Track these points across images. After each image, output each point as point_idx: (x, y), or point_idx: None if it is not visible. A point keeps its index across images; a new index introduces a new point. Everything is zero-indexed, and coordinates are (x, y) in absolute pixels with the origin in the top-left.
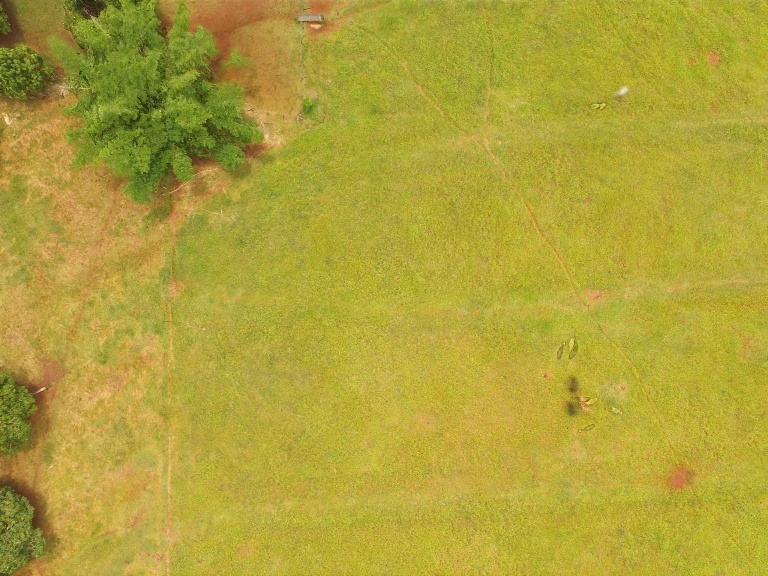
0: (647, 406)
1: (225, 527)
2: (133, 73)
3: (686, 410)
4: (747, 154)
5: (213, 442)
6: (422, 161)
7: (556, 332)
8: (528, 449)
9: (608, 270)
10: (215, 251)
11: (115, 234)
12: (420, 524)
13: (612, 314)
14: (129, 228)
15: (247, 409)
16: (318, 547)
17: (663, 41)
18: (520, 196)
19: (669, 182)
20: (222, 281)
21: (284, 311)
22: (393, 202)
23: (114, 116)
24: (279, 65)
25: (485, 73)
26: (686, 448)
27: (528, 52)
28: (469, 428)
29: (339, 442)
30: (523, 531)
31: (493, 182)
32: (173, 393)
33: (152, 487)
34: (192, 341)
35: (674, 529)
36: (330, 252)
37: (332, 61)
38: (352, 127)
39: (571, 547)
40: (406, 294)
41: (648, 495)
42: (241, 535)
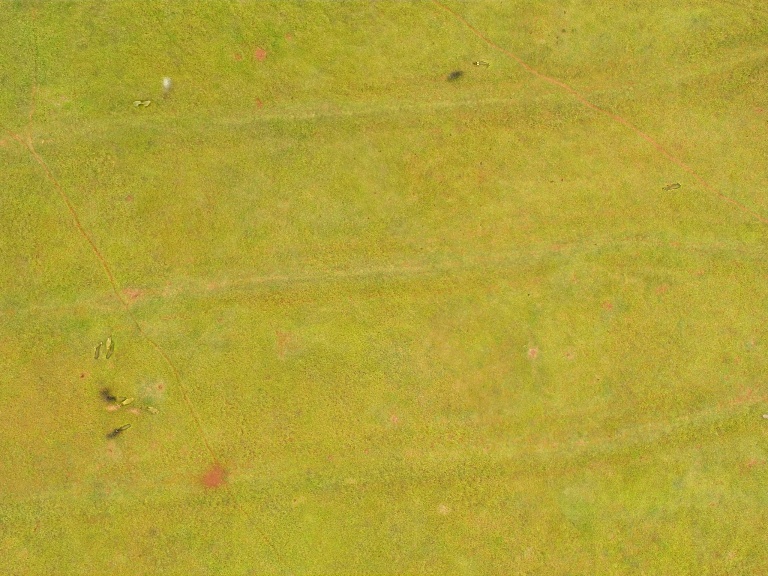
0: (183, 405)
1: None
2: None
3: (223, 408)
4: (291, 150)
5: None
6: None
7: (93, 332)
8: (63, 450)
9: (149, 268)
10: None
11: None
12: None
13: (151, 313)
14: None
15: None
16: None
17: (209, 37)
18: (63, 195)
19: (212, 179)
20: None
21: None
22: None
23: None
24: None
25: (30, 71)
26: (223, 447)
27: (72, 50)
28: (4, 430)
29: None
30: (54, 533)
31: (36, 181)
32: None
33: None
34: None
35: (207, 528)
36: None
37: None
38: None
39: (102, 548)
40: None
41: (182, 495)
42: None
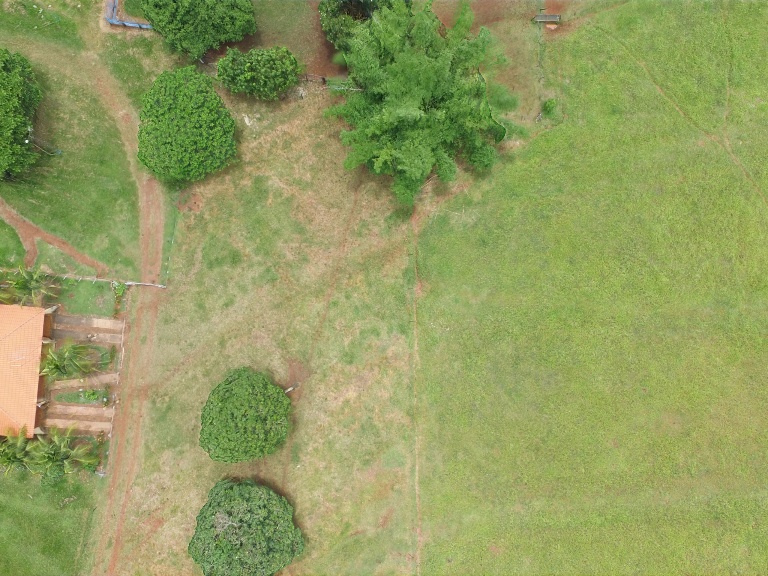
0: None
1: (475, 527)
2: (425, 74)
3: None
4: None
5: (460, 442)
6: (663, 161)
7: None
8: None
9: None
10: (458, 251)
11: (358, 234)
12: (669, 524)
13: None
14: (371, 228)
15: (493, 409)
16: (568, 547)
17: None
18: (761, 196)
19: None
20: (467, 281)
21: (530, 311)
22: (635, 202)
23: (398, 117)
24: (517, 65)
25: (724, 73)
26: None
27: (767, 52)
28: (715, 428)
29: (586, 442)
30: None
31: (734, 182)
32: (420, 393)
33: (400, 487)
34: (437, 341)
35: None
36: (573, 252)
37: (570, 61)
38: (592, 127)
39: None
40: (651, 294)
41: None
42: (491, 535)
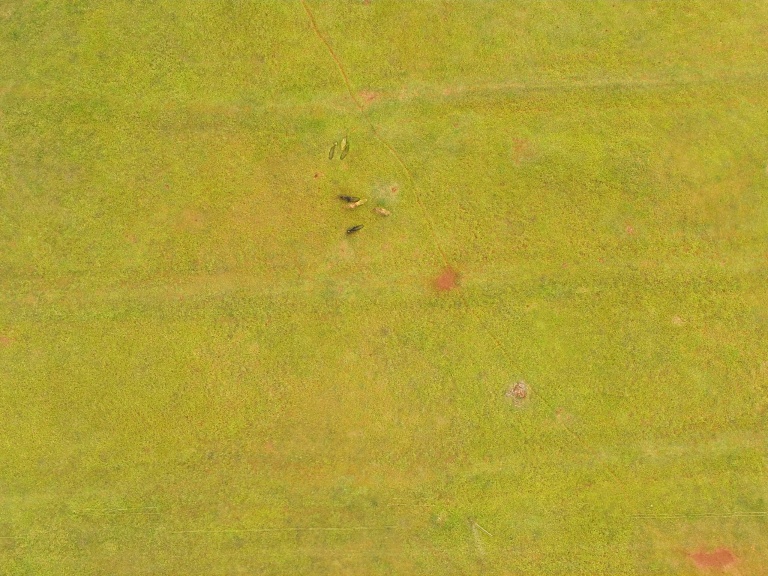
0: (417, 208)
1: None
2: None
3: (456, 213)
4: None
5: None
6: None
7: (328, 132)
8: (295, 248)
9: (384, 72)
10: None
11: None
12: (183, 320)
13: (386, 116)
14: None
15: (14, 201)
16: (78, 339)
17: None
18: None
19: None
20: None
21: (54, 104)
22: None
23: None
24: None
25: None
26: (455, 251)
27: None
28: (237, 226)
29: (105, 236)
30: (285, 328)
31: None
32: None
33: None
34: None
35: (438, 330)
36: (104, 47)
37: None
38: None
39: (333, 346)
40: (178, 90)
41: (414, 296)
42: (1, 326)
